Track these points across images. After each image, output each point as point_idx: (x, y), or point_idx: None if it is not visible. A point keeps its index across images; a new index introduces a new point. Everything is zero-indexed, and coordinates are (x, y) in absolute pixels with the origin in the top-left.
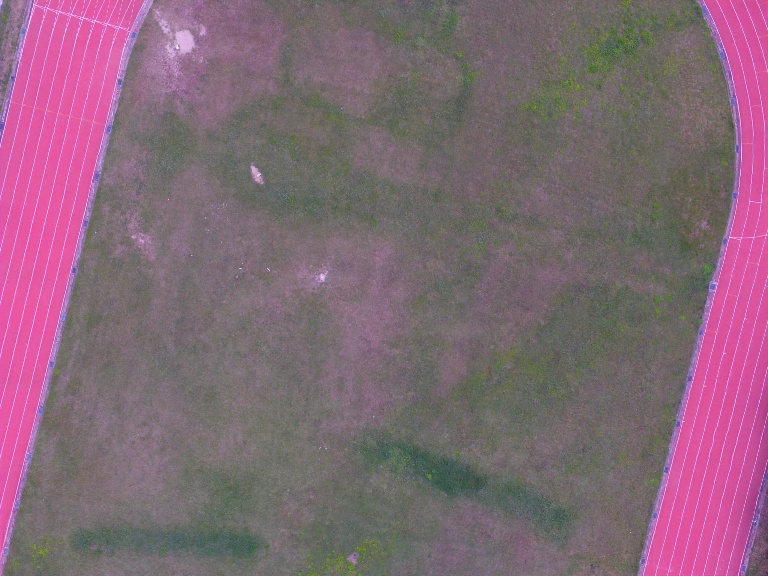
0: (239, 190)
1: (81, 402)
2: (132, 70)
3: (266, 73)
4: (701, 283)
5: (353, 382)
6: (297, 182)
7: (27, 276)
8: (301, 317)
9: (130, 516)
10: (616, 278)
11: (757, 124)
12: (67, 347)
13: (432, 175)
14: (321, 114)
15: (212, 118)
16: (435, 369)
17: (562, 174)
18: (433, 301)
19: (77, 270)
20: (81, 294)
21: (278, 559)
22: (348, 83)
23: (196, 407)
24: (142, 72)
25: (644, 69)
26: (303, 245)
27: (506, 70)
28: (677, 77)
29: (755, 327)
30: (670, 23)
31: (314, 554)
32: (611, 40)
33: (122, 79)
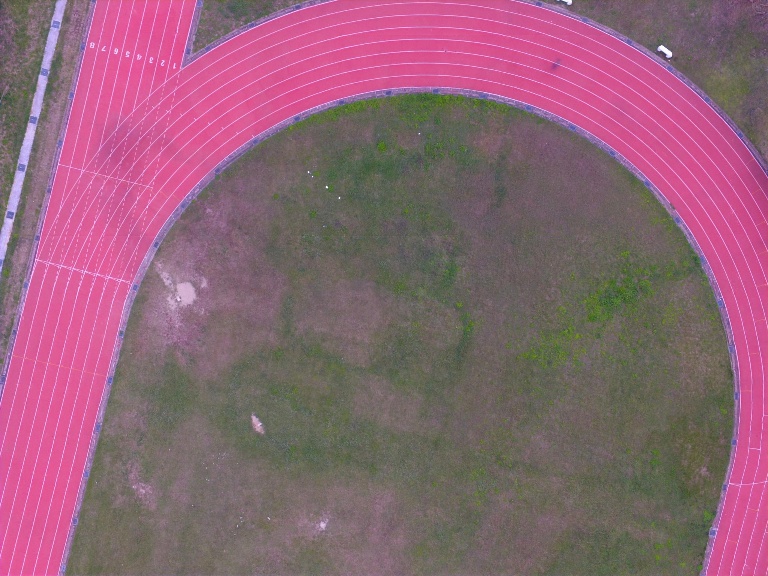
0: (240, 440)
1: None
2: (133, 322)
3: (267, 324)
4: (701, 529)
5: None
6: (298, 432)
7: (27, 527)
8: (301, 566)
9: None
10: (616, 525)
11: (756, 372)
12: None
13: (432, 423)
14: (322, 364)
15: (213, 369)
16: None
17: (562, 422)
18: (433, 549)
19: (78, 521)
20: (81, 545)
21: None
22: (348, 333)
23: None
24: (143, 324)
25: (643, 318)
26: (303, 494)
27: (506, 319)
28: (676, 326)
29: (755, 573)
30: (669, 273)
31: None
32: (610, 290)
33: (123, 330)
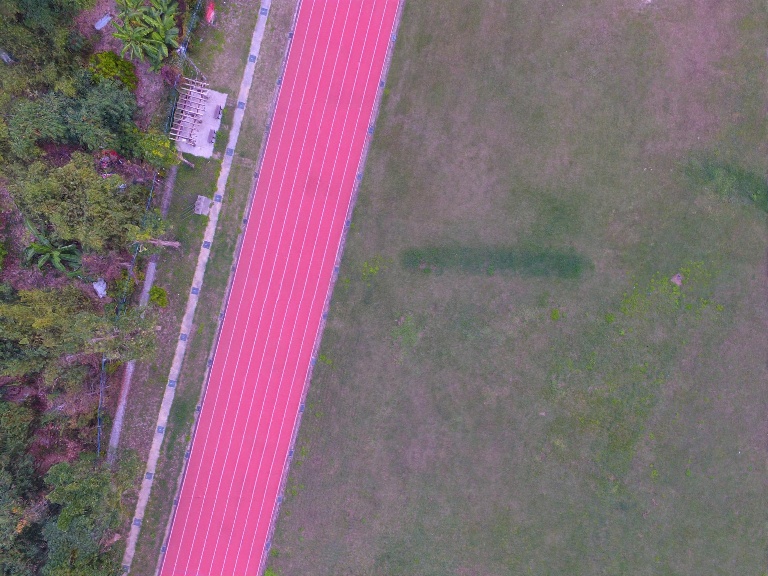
0: None
1: (411, 122)
2: None
3: None
4: None
5: (678, 103)
6: None
7: None
8: (628, 38)
9: (458, 235)
10: None
11: None
12: (398, 67)
13: None
14: None
15: None
16: (760, 90)
17: None
18: (759, 22)
19: None
20: (412, 14)
21: (603, 280)
22: None
23: (524, 127)
24: None
25: None
26: None
27: None
28: None
29: None
30: None
31: (639, 275)
32: None
33: None
